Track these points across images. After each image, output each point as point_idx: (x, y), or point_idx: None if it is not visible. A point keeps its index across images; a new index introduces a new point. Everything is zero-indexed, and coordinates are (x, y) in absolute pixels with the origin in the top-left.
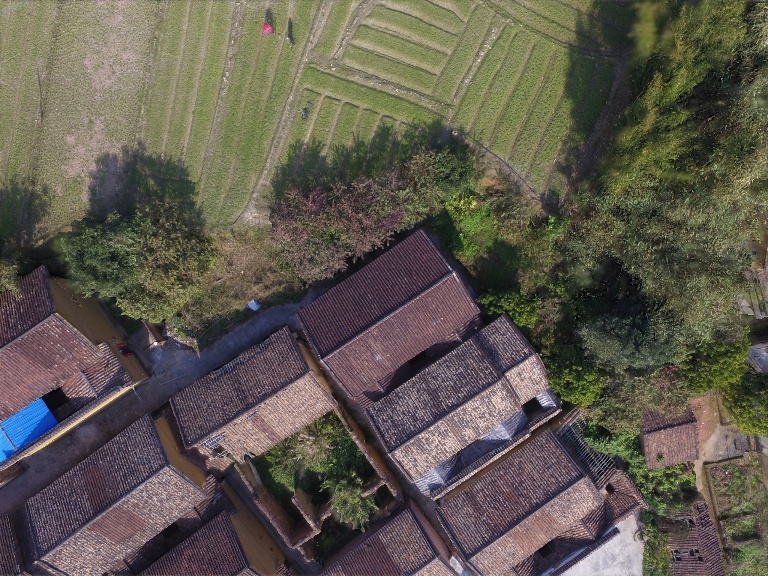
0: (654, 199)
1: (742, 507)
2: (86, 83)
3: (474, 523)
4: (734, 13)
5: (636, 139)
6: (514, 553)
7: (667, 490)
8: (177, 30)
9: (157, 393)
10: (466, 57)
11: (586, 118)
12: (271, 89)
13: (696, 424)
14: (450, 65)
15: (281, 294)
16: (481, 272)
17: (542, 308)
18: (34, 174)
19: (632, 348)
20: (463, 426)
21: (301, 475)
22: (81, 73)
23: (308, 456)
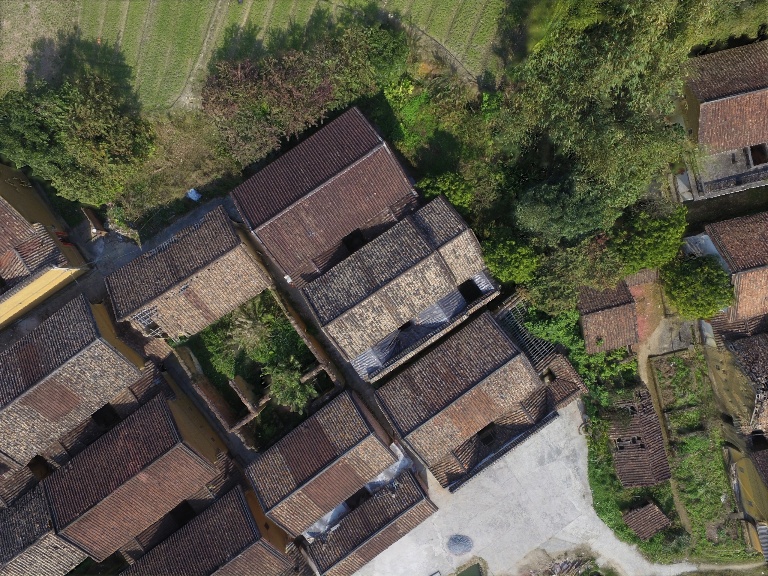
0: (578, 57)
1: (687, 399)
2: None
3: (411, 403)
4: None
5: (562, 1)
6: (452, 434)
7: (609, 378)
8: None
9: (99, 286)
10: None
11: None
12: None
13: (634, 305)
14: None
15: (221, 182)
16: (422, 163)
17: (477, 187)
18: None
19: (560, 212)
20: (398, 303)
21: (241, 364)
22: None
23: (248, 345)
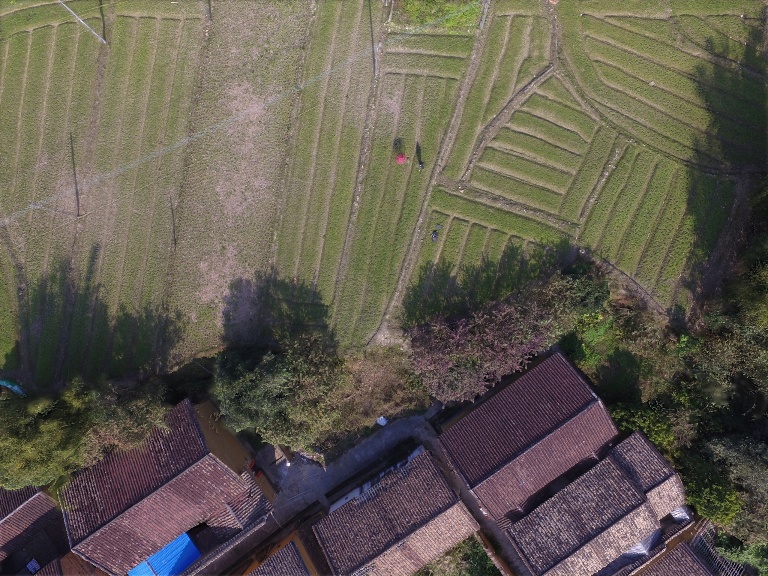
0: None
1: None
2: (218, 210)
3: None
4: None
5: None
6: None
7: None
8: (308, 156)
9: (284, 509)
10: (591, 177)
11: (710, 234)
12: (401, 212)
13: None
14: (576, 185)
15: (410, 410)
16: (603, 380)
17: (677, 425)
18: (168, 301)
19: None
20: (606, 547)
21: None
22: (213, 200)
23: (440, 571)
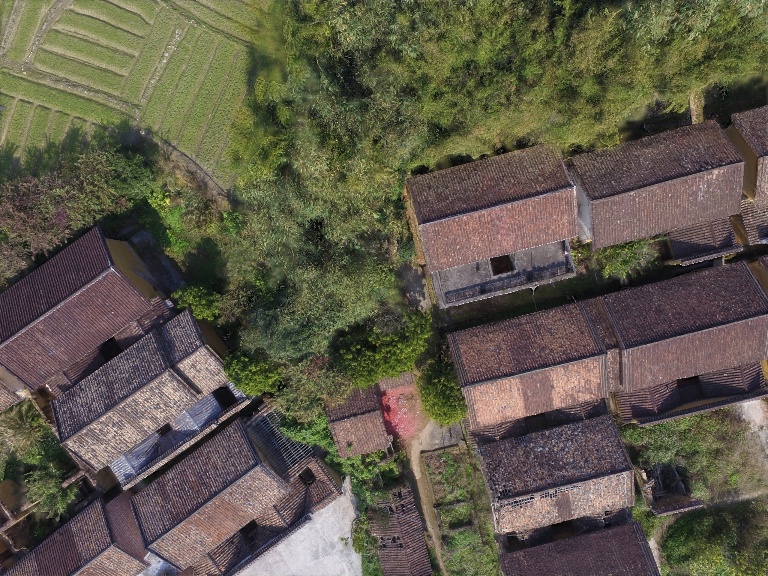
0: (275, 192)
1: (456, 495)
2: None
3: (160, 511)
4: (317, 10)
5: None
6: (202, 540)
7: (369, 478)
8: None
9: None
10: (151, 58)
11: None
12: None
13: (379, 412)
14: (136, 66)
15: None
16: (191, 267)
17: (220, 301)
18: None
19: (269, 338)
20: (139, 417)
21: (12, 467)
22: None
23: (19, 448)
